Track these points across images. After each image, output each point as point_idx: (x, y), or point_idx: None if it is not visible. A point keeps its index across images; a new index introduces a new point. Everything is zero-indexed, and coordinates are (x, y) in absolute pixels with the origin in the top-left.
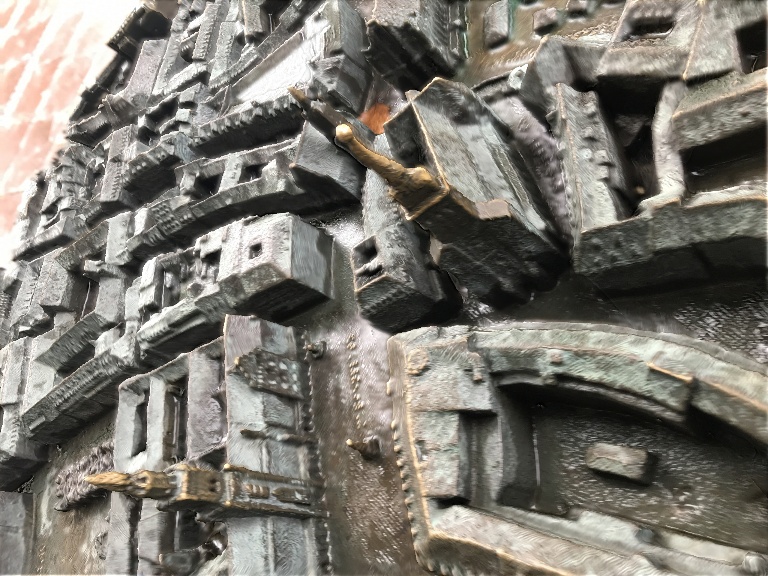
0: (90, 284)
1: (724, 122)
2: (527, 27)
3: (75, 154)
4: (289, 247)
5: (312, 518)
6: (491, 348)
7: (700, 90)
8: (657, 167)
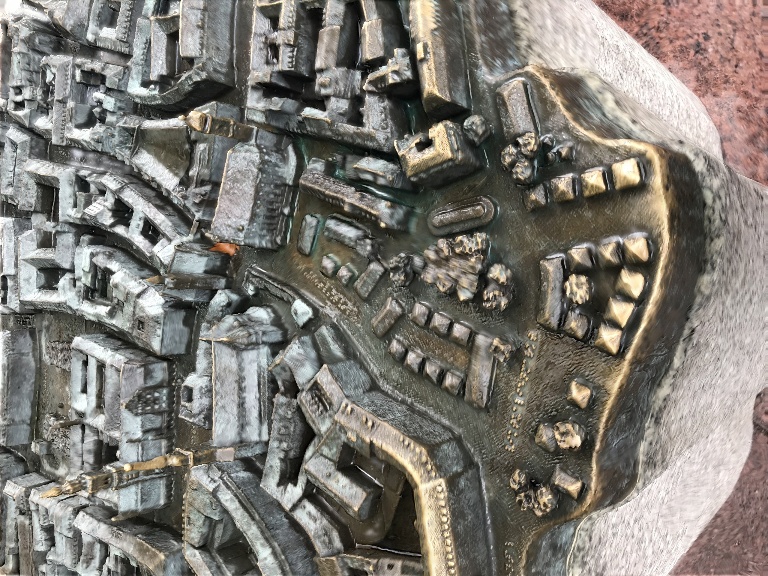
0: (55, 190)
1: (319, 485)
2: (322, 255)
3: (29, 44)
4: (160, 334)
5: (165, 477)
6: (221, 500)
7: (321, 458)
8: (299, 473)
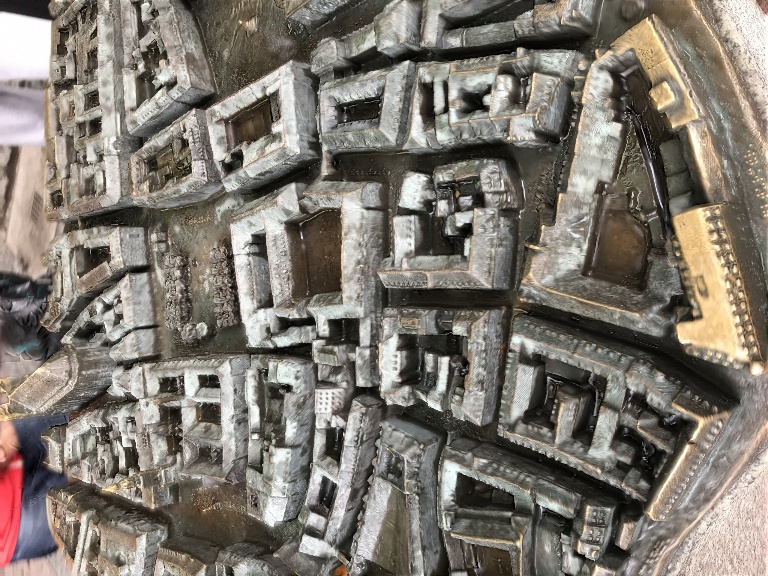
0: None
1: None
2: None
3: None
4: None
5: None
6: None
7: None
8: None
